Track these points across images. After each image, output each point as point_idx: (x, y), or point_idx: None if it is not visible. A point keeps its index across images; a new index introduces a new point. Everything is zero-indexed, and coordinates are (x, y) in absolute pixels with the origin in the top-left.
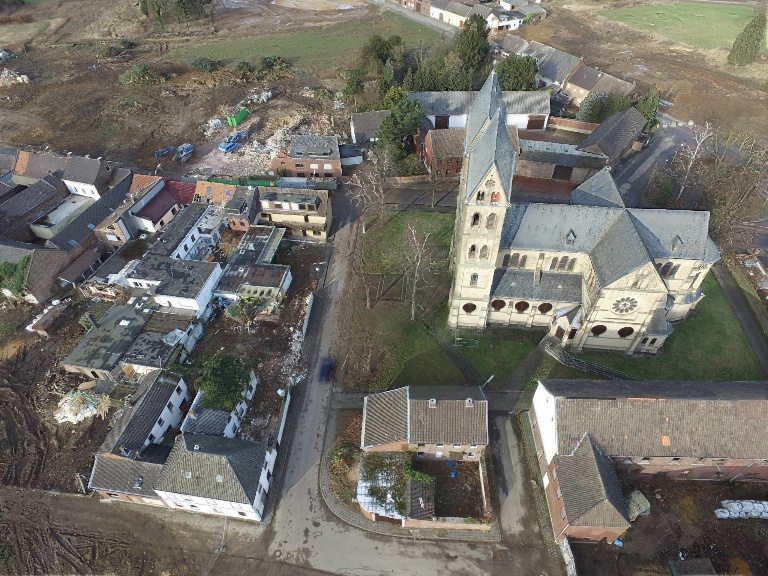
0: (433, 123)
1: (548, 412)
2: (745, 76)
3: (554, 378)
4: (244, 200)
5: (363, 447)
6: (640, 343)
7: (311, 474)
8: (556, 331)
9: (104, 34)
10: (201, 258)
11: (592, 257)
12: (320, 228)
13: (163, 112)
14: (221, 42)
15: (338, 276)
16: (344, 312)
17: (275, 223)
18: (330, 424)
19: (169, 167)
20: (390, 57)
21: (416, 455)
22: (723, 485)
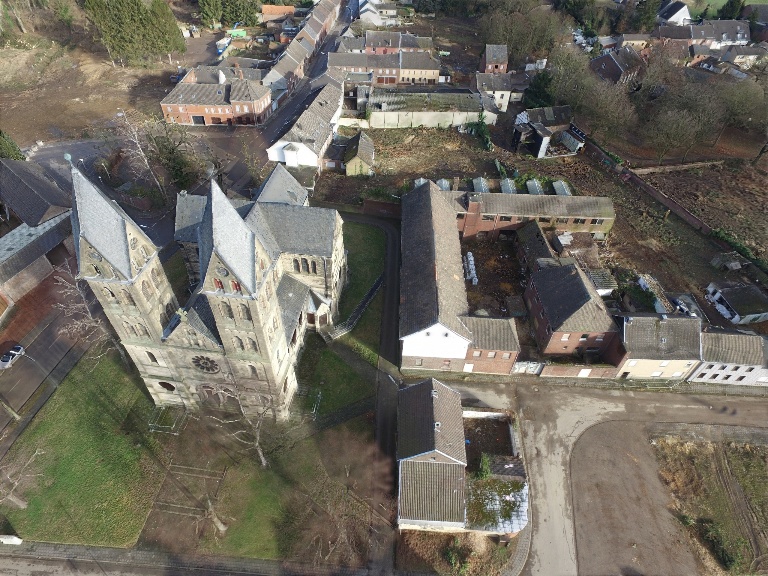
0: None
1: (438, 337)
2: None
3: (365, 341)
4: None
5: None
6: None
7: None
8: (319, 323)
9: None
10: None
11: (288, 251)
12: None
13: None
14: None
15: None
16: (218, 574)
17: None
18: None
19: None
20: None
21: None
22: None
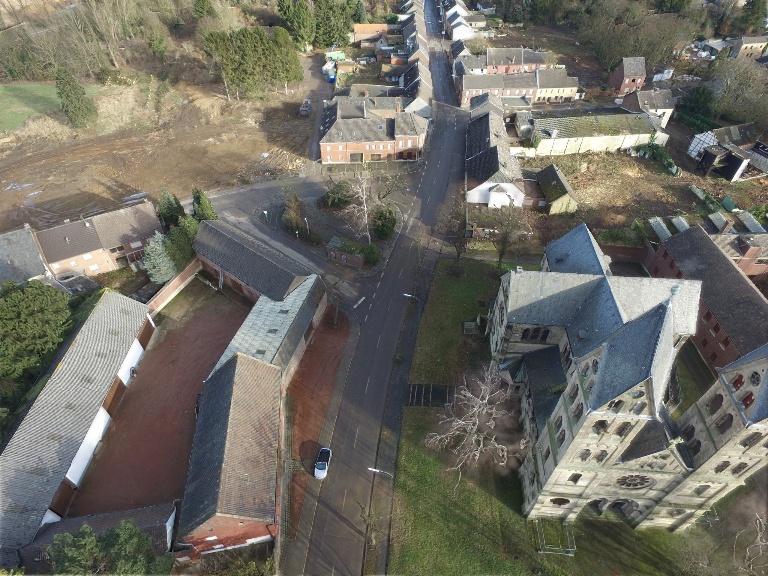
0: (52, 519)
1: None
2: (112, 130)
3: None
4: None
5: None
6: None
7: None
8: None
9: None
10: None
11: None
12: None
13: None
14: None
15: None
16: None
17: None
18: None
19: None
20: None
21: None
22: None
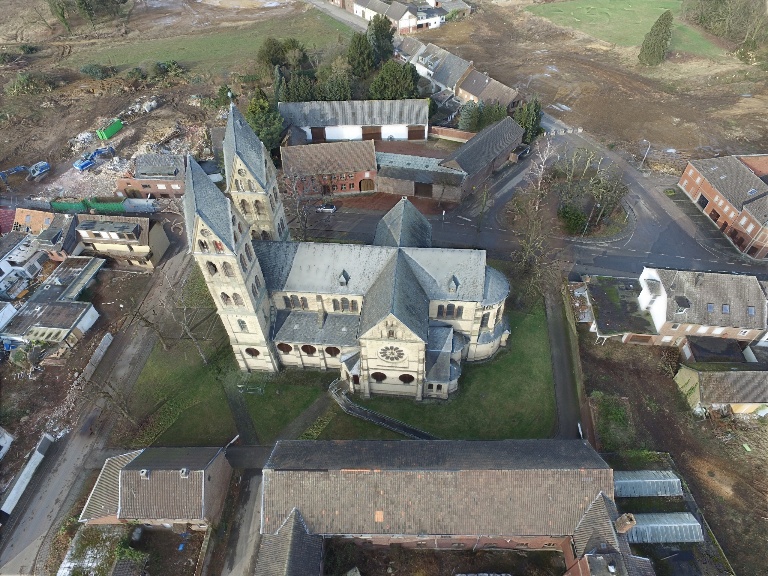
0: (309, 135)
1: None
2: (654, 76)
3: (331, 429)
4: (60, 230)
5: (79, 520)
6: (427, 389)
7: (31, 548)
8: (346, 375)
9: (9, 38)
10: (12, 293)
11: (364, 300)
12: (143, 258)
13: (36, 125)
14: (127, 45)
15: (150, 311)
16: (140, 353)
17: (96, 253)
18: (75, 487)
19: (20, 188)
20: (285, 62)
21: (144, 526)
22: (464, 555)
